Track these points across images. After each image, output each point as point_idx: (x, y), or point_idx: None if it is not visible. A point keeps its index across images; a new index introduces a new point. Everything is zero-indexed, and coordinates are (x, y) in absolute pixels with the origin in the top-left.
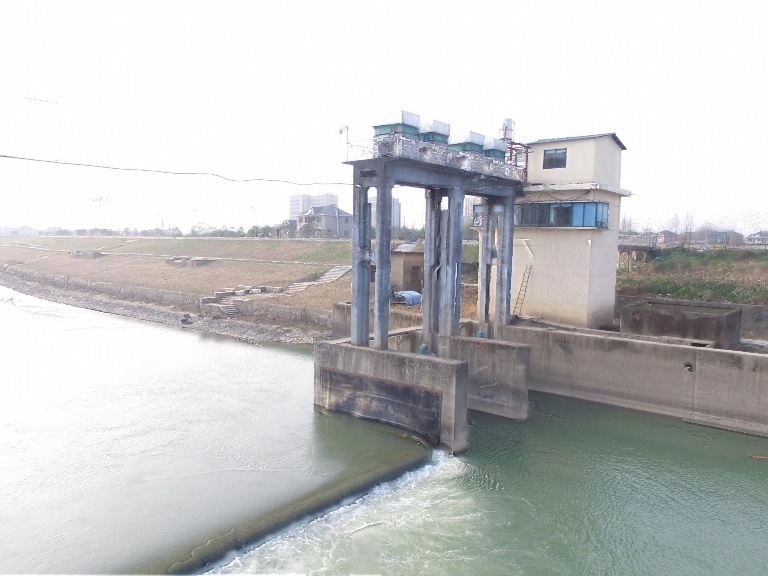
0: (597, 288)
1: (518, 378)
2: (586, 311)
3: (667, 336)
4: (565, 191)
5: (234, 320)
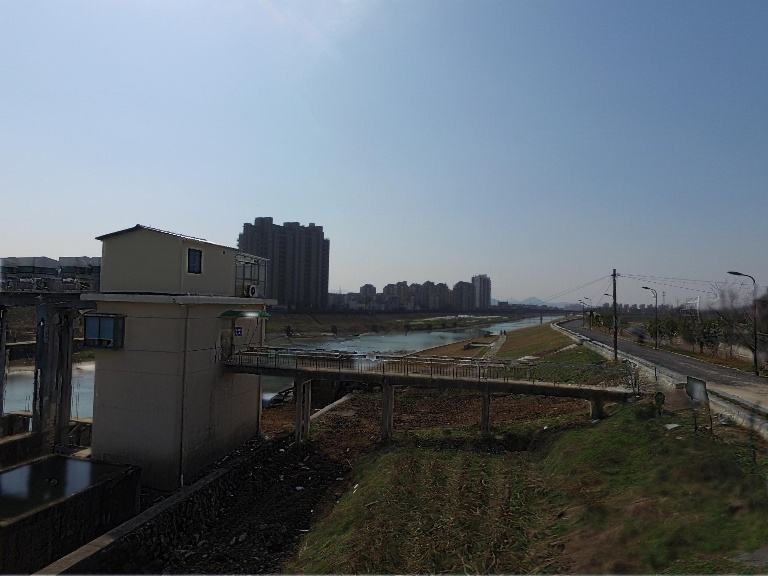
0: (116, 424)
1: None
2: None
3: None
4: None
5: None
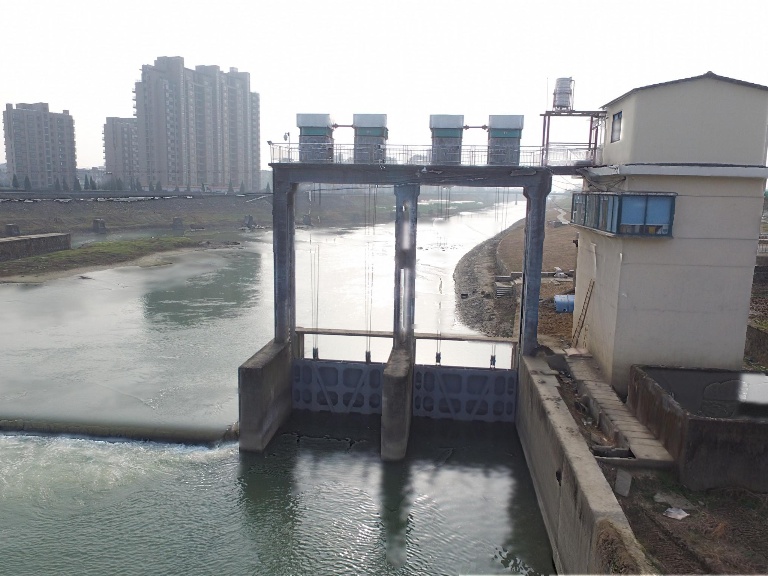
0: (654, 329)
1: (383, 410)
2: (611, 360)
3: (641, 427)
4: (601, 177)
5: (491, 301)
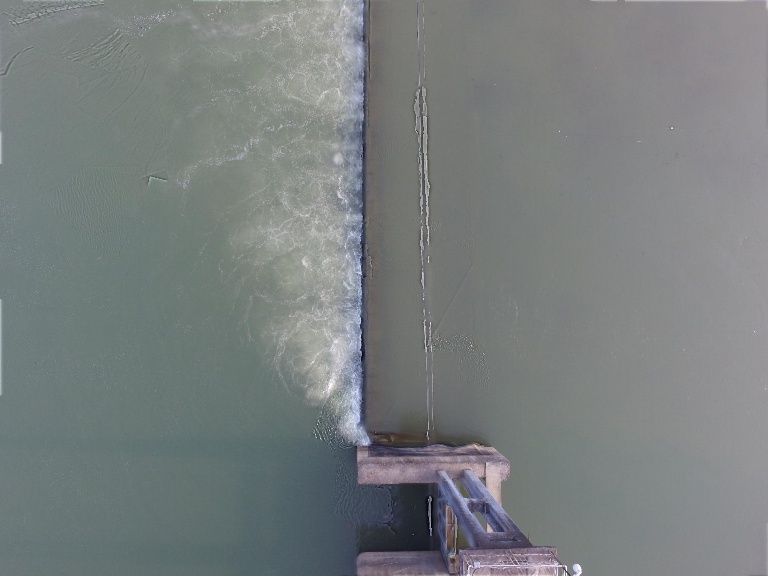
0: None
1: (362, 571)
2: None
3: None
4: None
5: None
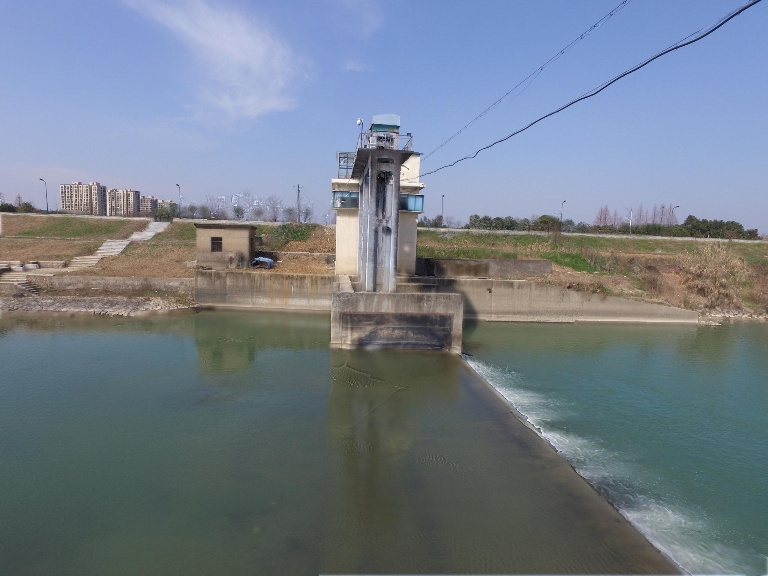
0: None
1: None
2: None
3: None
4: (404, 187)
5: (49, 296)
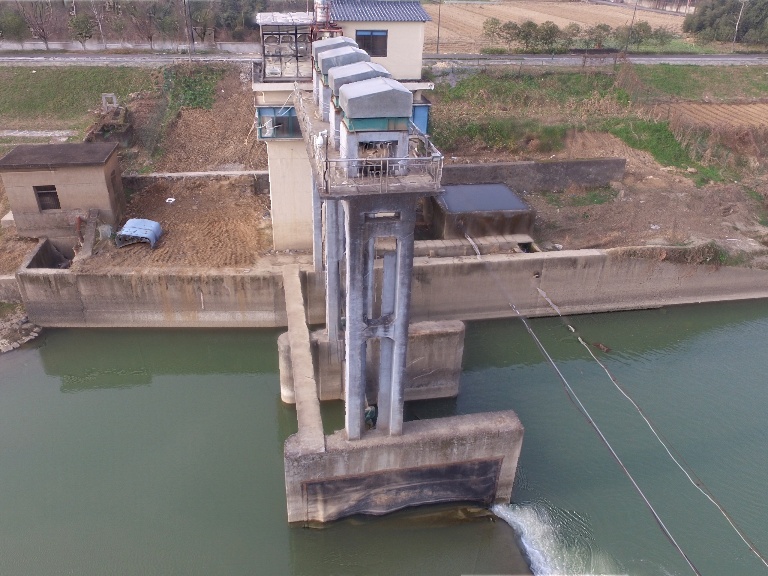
0: None
1: (459, 360)
2: None
3: (490, 237)
4: None
5: None
